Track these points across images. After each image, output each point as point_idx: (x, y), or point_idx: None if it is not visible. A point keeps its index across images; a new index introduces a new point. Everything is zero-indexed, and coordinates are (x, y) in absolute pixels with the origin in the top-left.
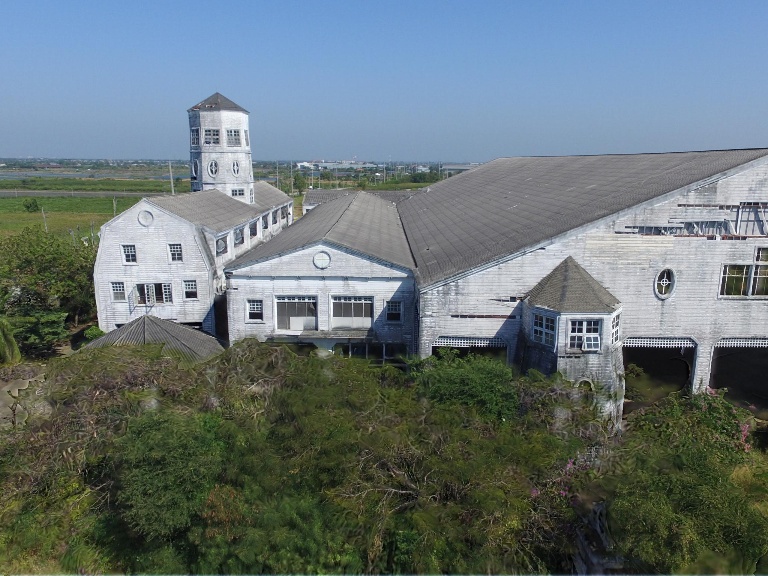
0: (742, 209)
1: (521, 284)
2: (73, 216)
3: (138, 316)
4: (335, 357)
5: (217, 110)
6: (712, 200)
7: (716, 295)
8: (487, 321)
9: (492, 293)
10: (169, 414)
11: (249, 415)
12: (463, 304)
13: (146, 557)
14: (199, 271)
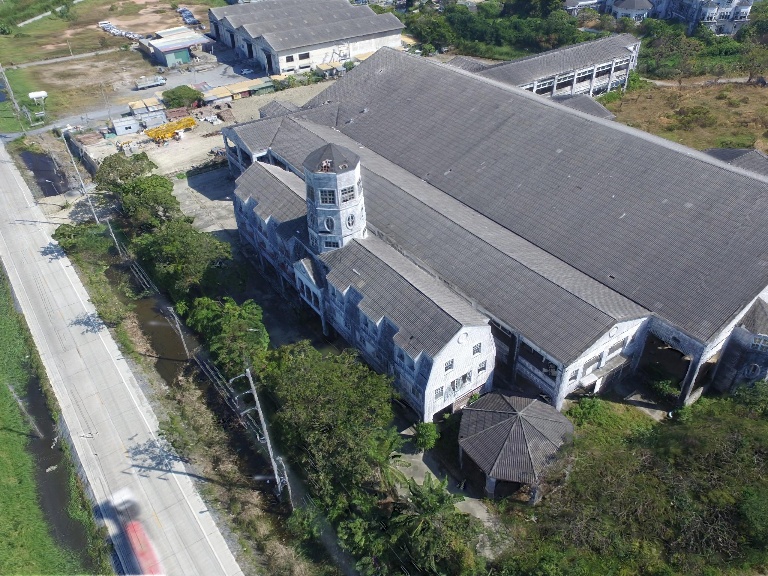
0: None
1: None
2: None
3: (449, 401)
4: None
5: (352, 169)
6: None
7: None
8: None
9: None
10: None
11: (757, 478)
12: None
13: (754, 559)
14: (489, 353)
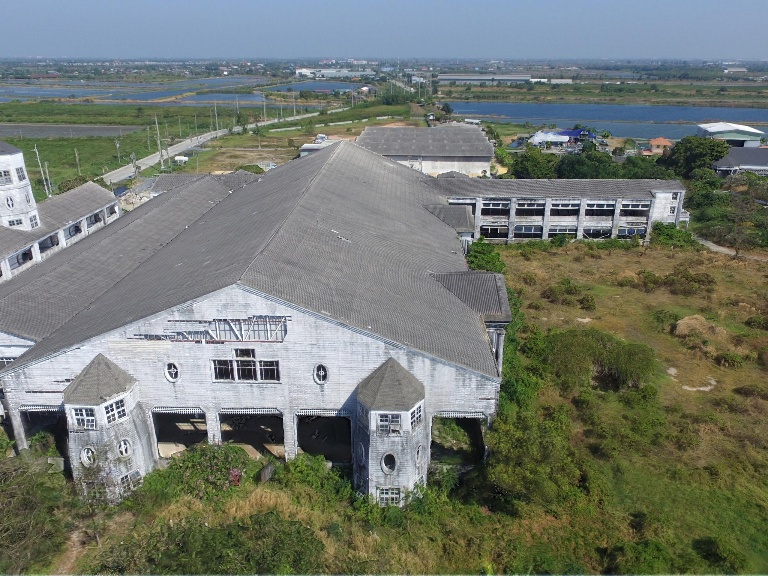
0: (218, 322)
1: (70, 371)
2: None
3: None
4: None
5: None
6: (192, 317)
7: (211, 380)
8: (53, 395)
9: (51, 377)
10: None
11: None
12: (32, 384)
13: None
14: None
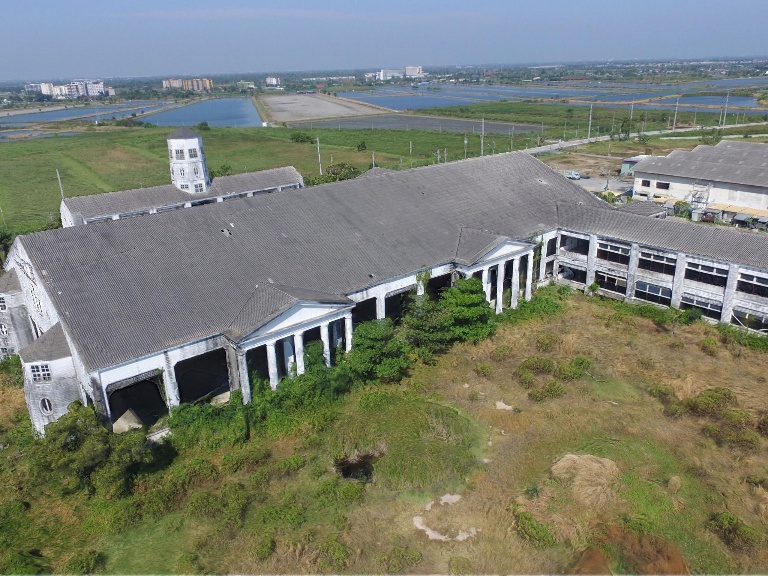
0: None
1: None
2: (367, 158)
3: None
4: None
5: None
6: None
7: None
8: None
9: None
10: None
11: None
12: None
13: None
14: None
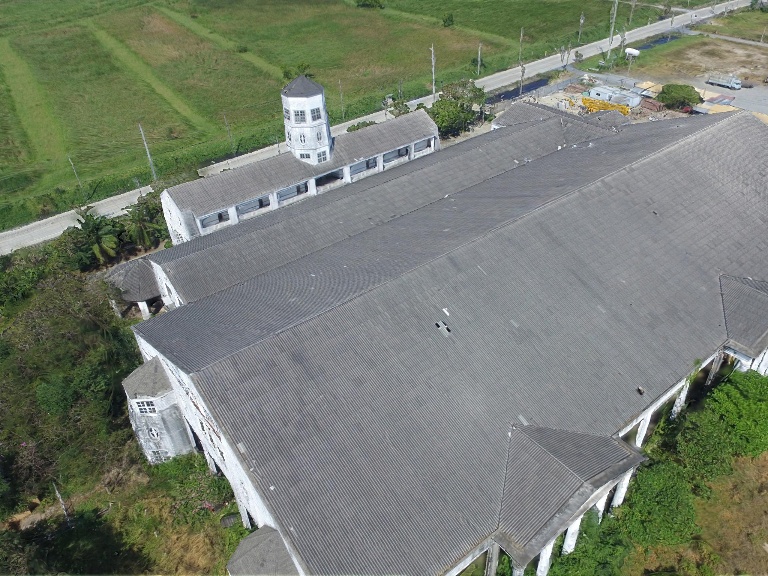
0: None
1: None
2: (459, 41)
3: None
4: (51, 349)
5: None
6: None
7: None
8: None
9: None
10: (2, 343)
11: None
12: None
13: None
14: None
